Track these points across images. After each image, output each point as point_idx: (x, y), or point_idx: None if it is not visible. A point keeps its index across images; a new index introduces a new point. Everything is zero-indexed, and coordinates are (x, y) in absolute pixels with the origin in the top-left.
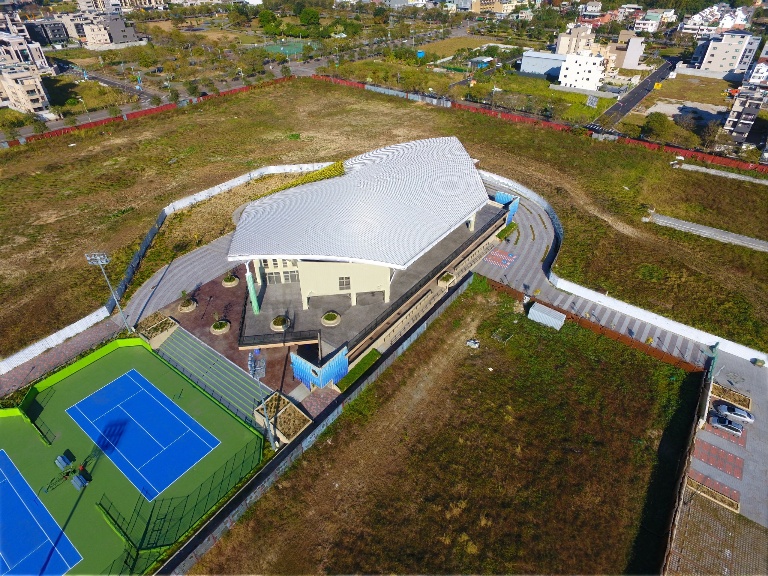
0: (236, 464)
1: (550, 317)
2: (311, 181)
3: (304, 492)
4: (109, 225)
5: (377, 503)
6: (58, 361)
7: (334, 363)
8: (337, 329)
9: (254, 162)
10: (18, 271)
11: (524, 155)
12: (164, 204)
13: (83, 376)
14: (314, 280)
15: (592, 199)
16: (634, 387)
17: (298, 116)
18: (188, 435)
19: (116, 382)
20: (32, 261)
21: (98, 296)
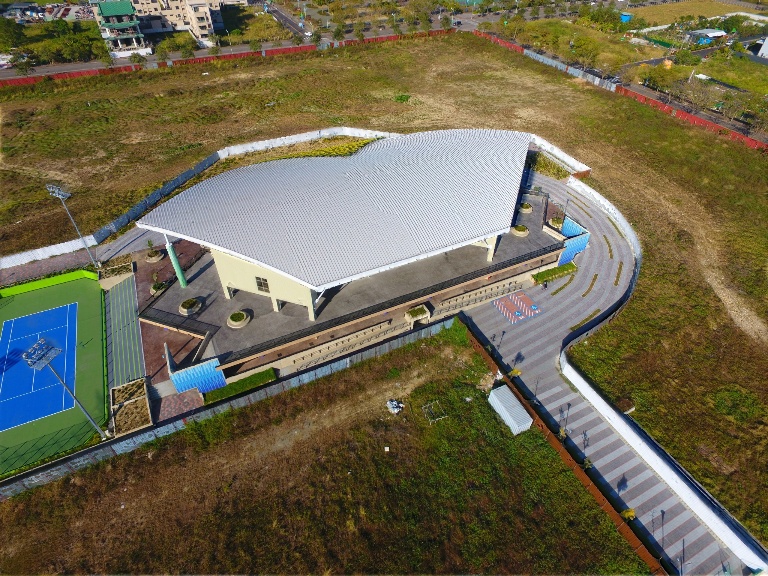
0: (65, 436)
1: (508, 413)
2: (313, 155)
3: (90, 498)
4: (170, 157)
5: (137, 550)
6: (32, 274)
7: (196, 372)
8: (236, 333)
9: (340, 119)
10: (77, 182)
11: (668, 174)
12: (228, 146)
13: (40, 295)
14: (231, 271)
15: (725, 261)
16: (558, 570)
17: (426, 76)
18: (58, 387)
19: (55, 310)
20: (92, 176)
21: (104, 223)
